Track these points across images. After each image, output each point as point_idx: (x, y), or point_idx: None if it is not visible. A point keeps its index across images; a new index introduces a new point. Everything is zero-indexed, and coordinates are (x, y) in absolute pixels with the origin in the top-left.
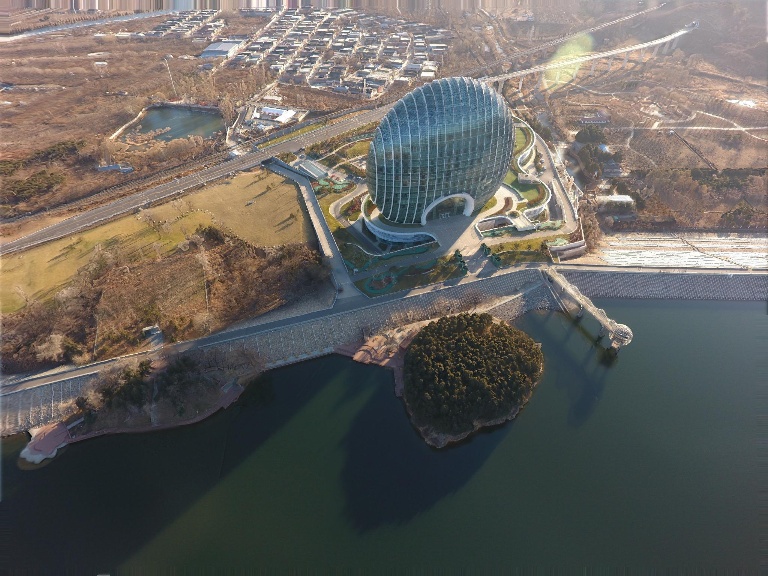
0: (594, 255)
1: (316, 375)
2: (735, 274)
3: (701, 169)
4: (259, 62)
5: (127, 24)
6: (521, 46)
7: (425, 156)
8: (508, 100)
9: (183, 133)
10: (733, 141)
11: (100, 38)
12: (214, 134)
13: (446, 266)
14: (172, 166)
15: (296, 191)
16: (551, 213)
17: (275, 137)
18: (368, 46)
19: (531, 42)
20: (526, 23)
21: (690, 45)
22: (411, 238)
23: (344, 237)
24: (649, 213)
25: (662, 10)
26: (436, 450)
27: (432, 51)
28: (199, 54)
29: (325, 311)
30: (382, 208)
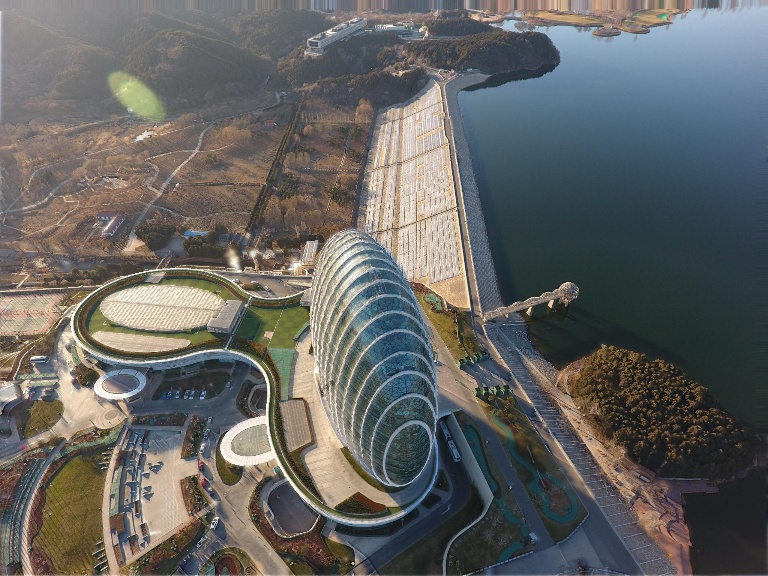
0: None
1: None
2: None
3: (263, 190)
4: None
5: None
6: None
7: None
8: None
9: None
10: (216, 162)
11: None
12: None
13: (507, 407)
14: None
15: None
16: None
17: None
18: None
19: None
20: None
21: None
22: None
23: (416, 569)
24: None
25: None
26: (759, 457)
27: None
28: None
29: None
30: None
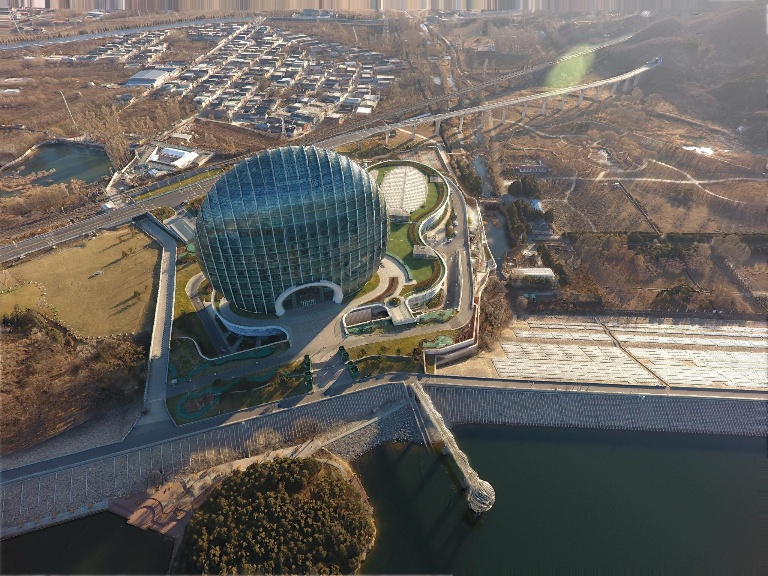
0: (488, 355)
1: (70, 548)
2: (648, 395)
3: (641, 233)
4: (186, 92)
5: (64, 46)
6: (475, 79)
7: (259, 242)
8: (446, 142)
9: (67, 176)
10: (683, 197)
11: (27, 61)
12: (101, 179)
13: (286, 379)
14: (32, 220)
15: (157, 259)
16: (448, 295)
17: (160, 187)
18: (310, 76)
19: (486, 75)
20: (486, 54)
21: (652, 82)
22: (263, 332)
23: (187, 326)
24: (571, 291)
25: (627, 44)
26: None
27: (377, 83)
28: (124, 82)
29: (111, 446)
30: (224, 297)
